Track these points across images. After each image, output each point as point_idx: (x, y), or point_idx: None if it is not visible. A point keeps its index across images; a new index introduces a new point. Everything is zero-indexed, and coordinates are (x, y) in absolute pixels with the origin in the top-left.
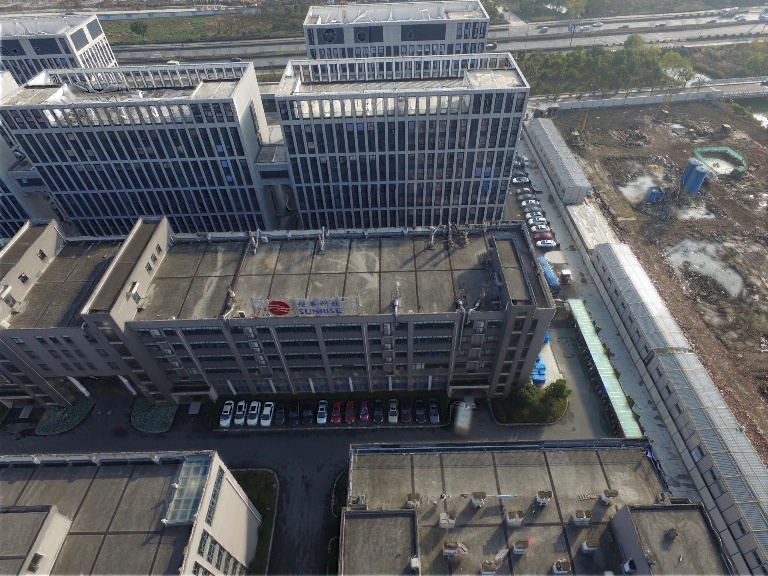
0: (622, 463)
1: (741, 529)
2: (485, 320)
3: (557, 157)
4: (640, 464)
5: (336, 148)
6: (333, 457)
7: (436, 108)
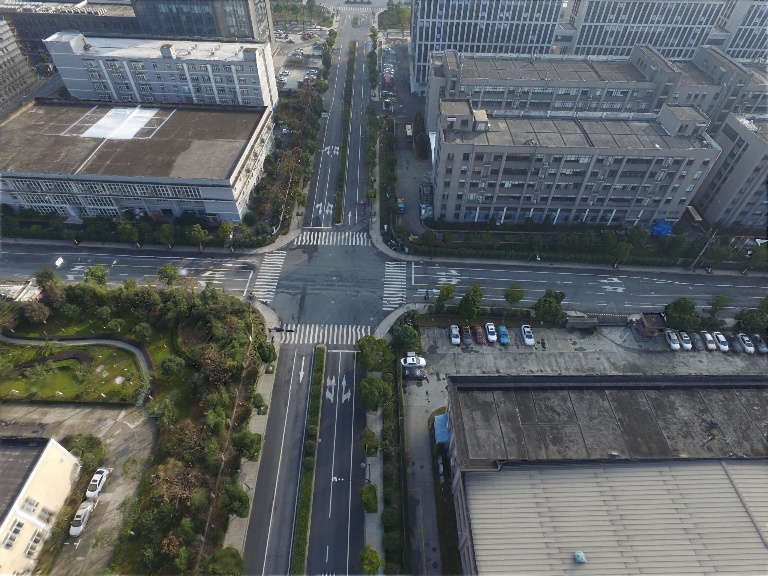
0: None
1: None
2: None
3: None
4: None
5: None
6: None
7: None
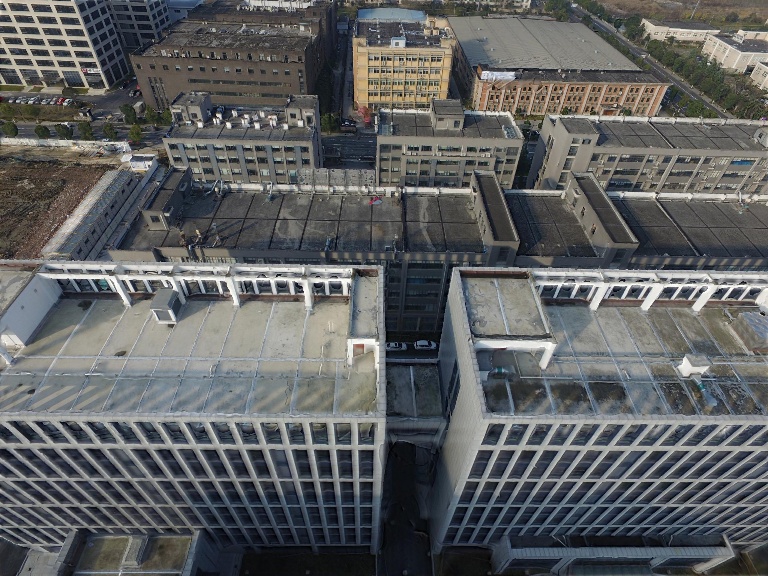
0: (183, 134)
1: None
2: None
3: None
4: (175, 134)
5: None
6: None
7: None
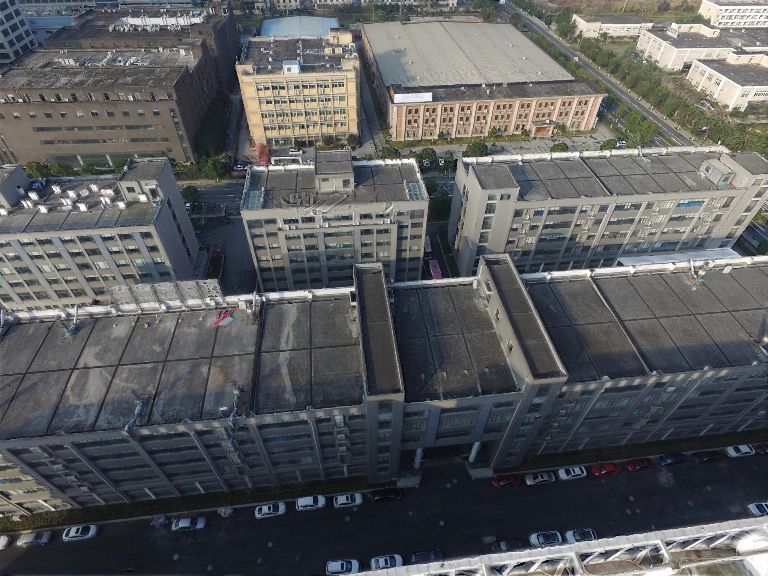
0: None
1: None
2: None
3: None
4: None
5: None
6: None
7: None
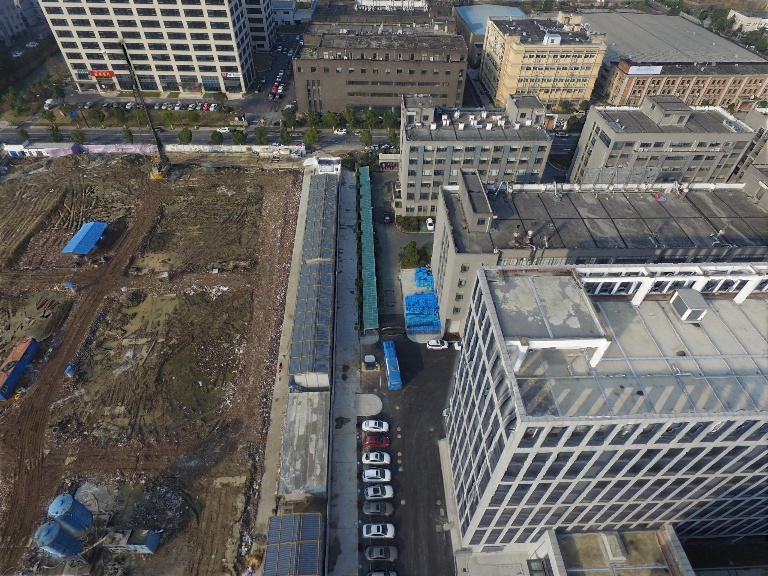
0: (422, 137)
1: None
2: None
3: None
4: (414, 136)
5: None
6: None
7: (619, 287)
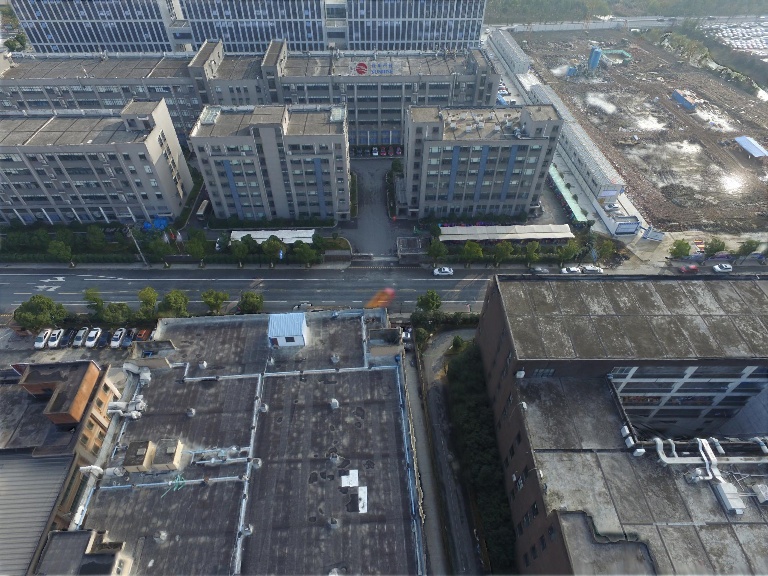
0: None
1: (588, 174)
2: (466, 82)
3: (511, 49)
4: None
5: (377, 15)
6: (384, 166)
7: None
